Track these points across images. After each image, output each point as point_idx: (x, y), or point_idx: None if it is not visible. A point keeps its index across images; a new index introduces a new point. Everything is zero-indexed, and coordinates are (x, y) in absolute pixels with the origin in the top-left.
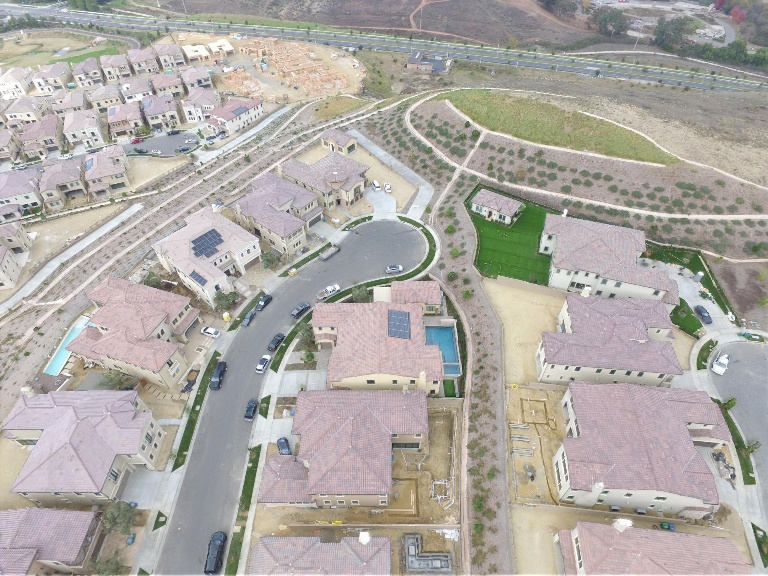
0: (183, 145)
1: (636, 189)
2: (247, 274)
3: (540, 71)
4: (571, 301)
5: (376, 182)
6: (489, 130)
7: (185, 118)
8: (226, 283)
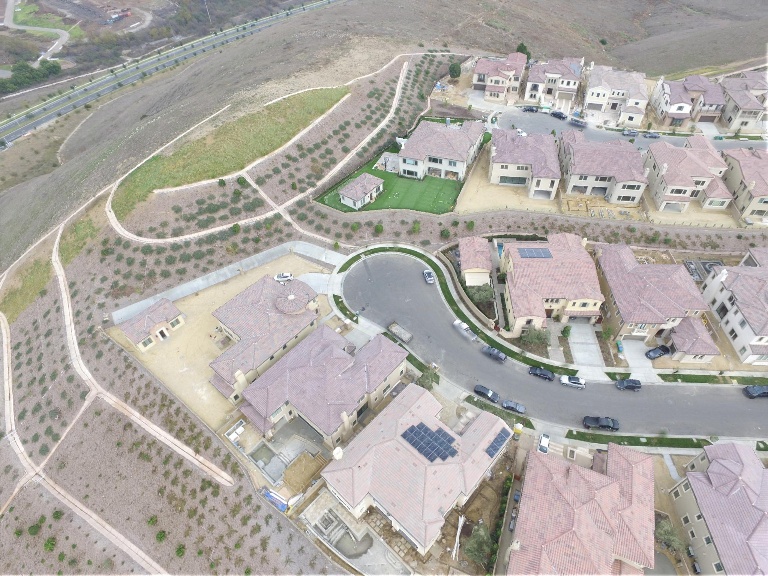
0: None
1: (364, 116)
2: None
3: None
4: (501, 160)
5: None
6: (240, 171)
7: None
8: None
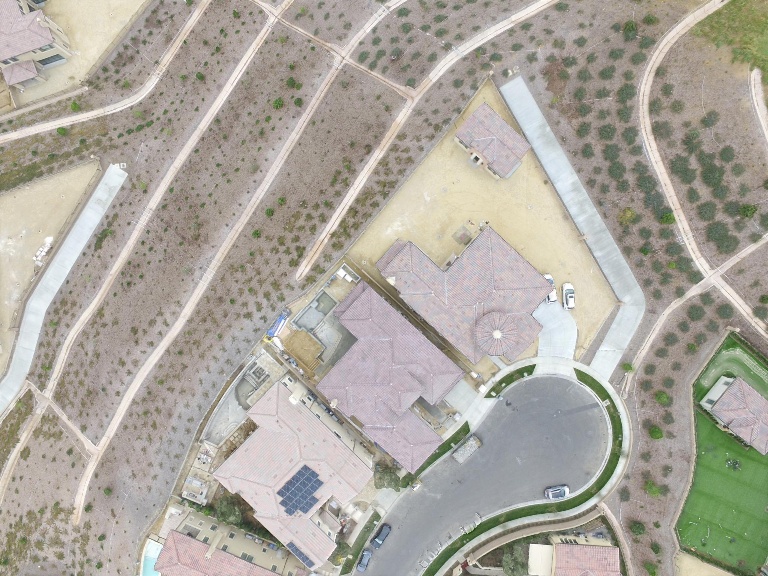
0: None
1: None
2: None
3: None
4: None
5: None
6: None
7: None
8: None
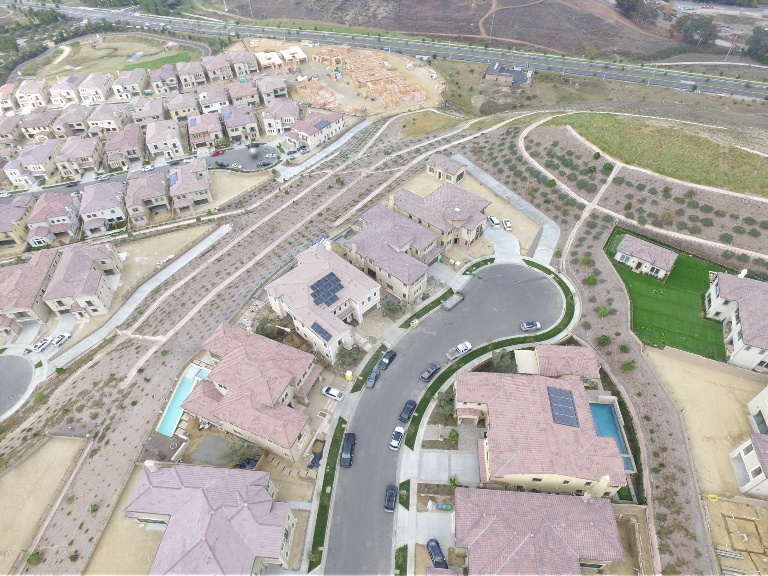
0: (263, 159)
1: None
2: (364, 323)
3: (630, 85)
4: None
5: (495, 218)
6: (623, 163)
7: (264, 130)
8: (349, 337)
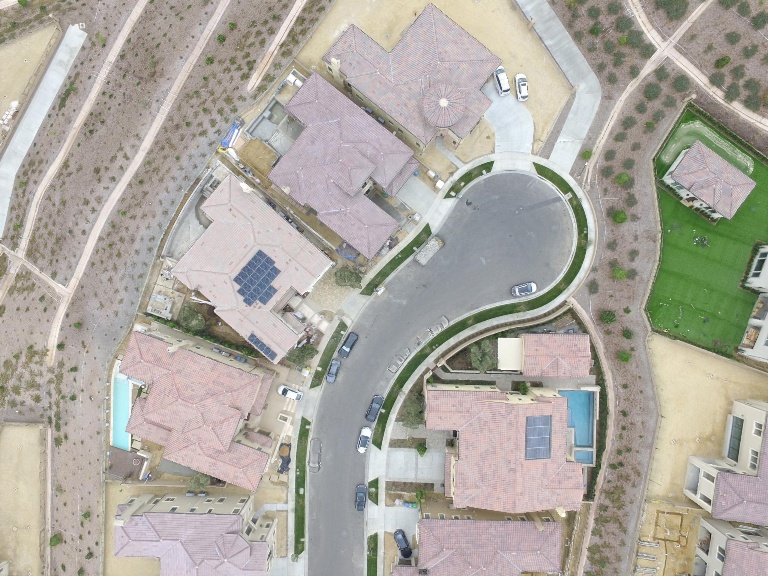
0: None
1: None
2: (316, 291)
3: None
4: None
5: (504, 78)
6: None
7: None
8: None
